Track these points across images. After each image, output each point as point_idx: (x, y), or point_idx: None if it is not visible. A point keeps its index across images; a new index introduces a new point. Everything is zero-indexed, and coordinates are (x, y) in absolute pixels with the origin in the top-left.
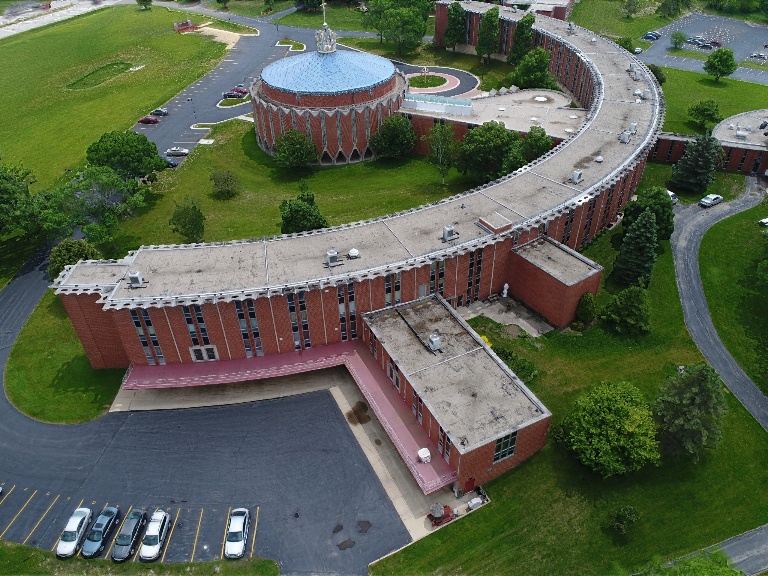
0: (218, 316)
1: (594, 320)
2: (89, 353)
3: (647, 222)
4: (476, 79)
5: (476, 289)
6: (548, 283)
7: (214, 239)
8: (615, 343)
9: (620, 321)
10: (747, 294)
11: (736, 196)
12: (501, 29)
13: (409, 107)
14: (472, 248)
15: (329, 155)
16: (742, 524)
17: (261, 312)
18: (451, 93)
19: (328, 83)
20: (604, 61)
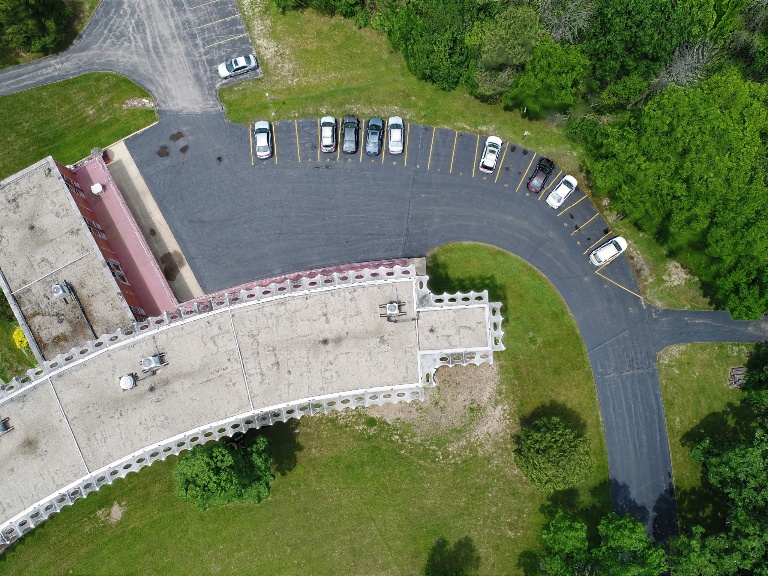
0: None
1: None
2: None
3: None
4: None
5: None
6: None
7: None
8: None
9: None
10: None
11: None
12: None
13: None
14: None
15: None
16: None
17: None
18: None
19: None
20: None
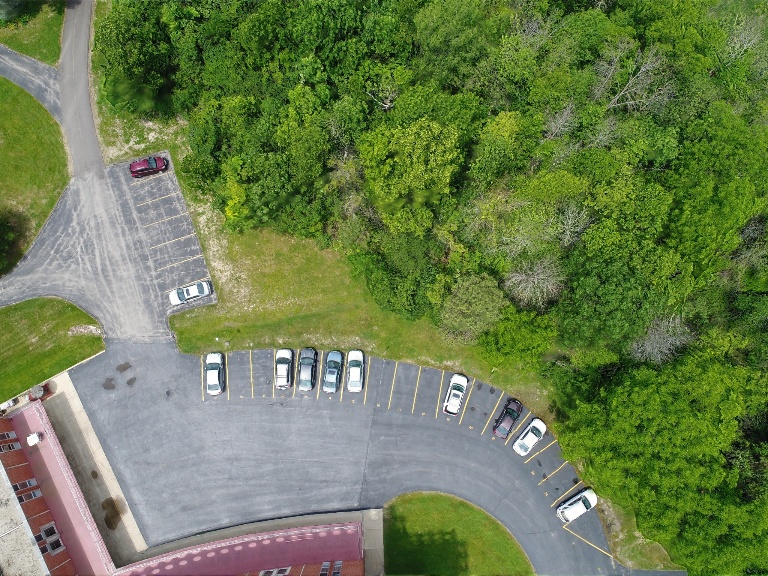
0: None
1: None
2: None
3: None
4: None
5: None
6: None
7: None
8: None
9: None
10: None
11: None
12: None
13: None
14: None
15: None
16: None
17: None
18: None
19: None
20: None
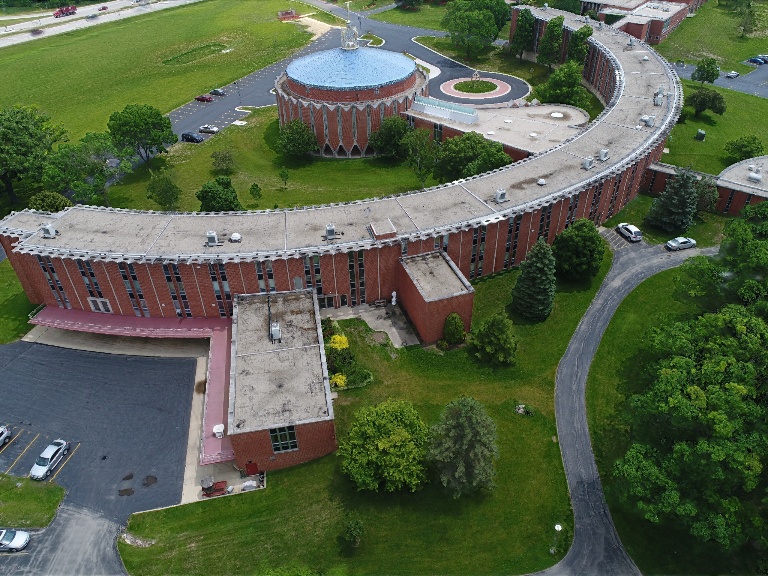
0: (105, 274)
1: (465, 343)
2: (25, 289)
3: (539, 252)
4: (528, 89)
5: (362, 292)
6: (417, 296)
7: (189, 210)
8: (470, 369)
9: (482, 348)
10: (649, 347)
11: (716, 243)
12: (565, 39)
13: (417, 110)
14: (345, 250)
15: (330, 148)
16: (476, 570)
17: (141, 276)
18: (493, 101)
19: (337, 79)
20: (638, 82)
